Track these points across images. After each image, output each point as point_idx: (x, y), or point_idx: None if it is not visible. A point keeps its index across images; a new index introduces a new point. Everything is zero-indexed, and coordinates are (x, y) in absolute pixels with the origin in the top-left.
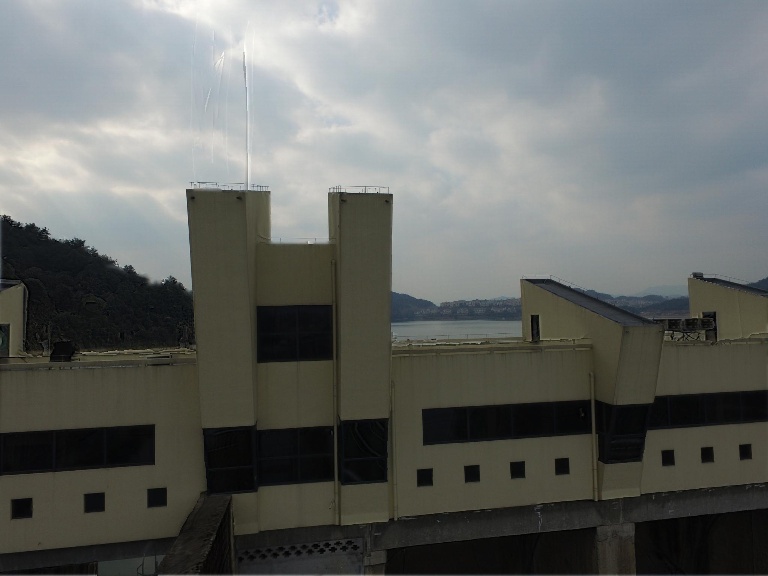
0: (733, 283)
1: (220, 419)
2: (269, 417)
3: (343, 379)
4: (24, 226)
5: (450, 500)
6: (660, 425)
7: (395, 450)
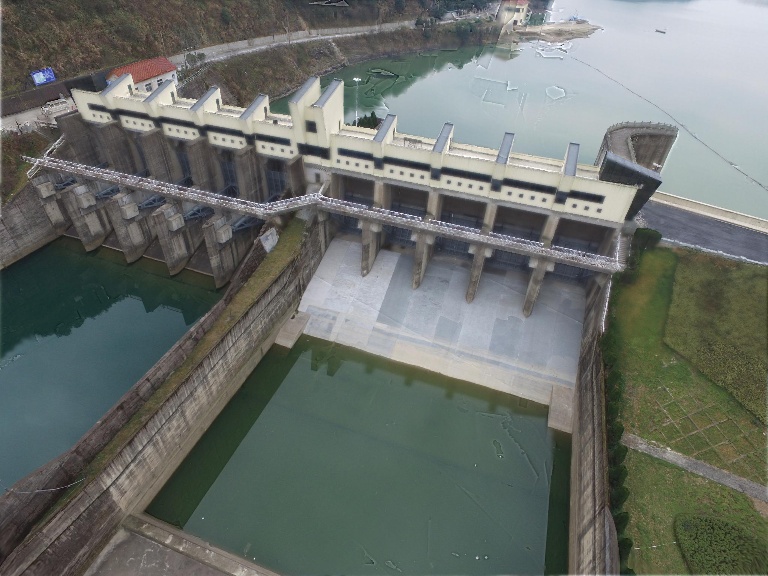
0: None
1: (299, 141)
2: (309, 142)
3: (318, 139)
4: None
5: (343, 167)
6: (391, 164)
7: (332, 154)
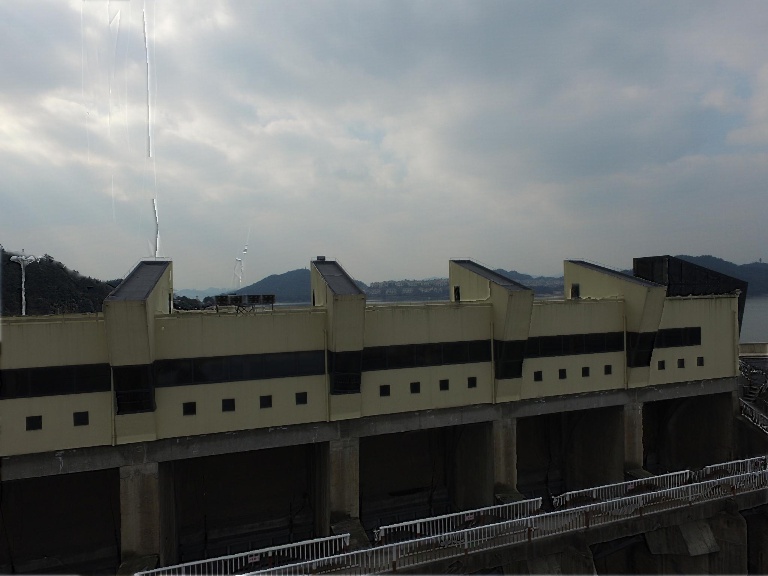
0: (336, 265)
1: None
2: None
3: None
4: None
5: None
6: (183, 382)
7: None
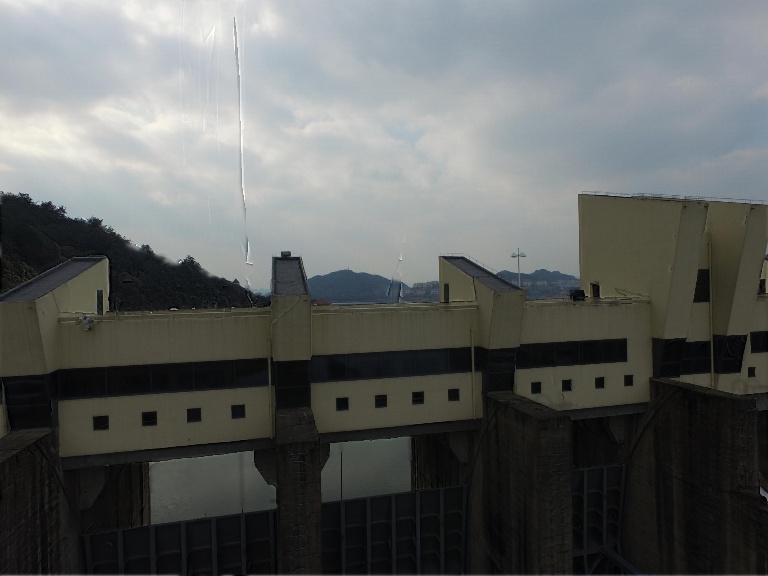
0: None
1: (671, 334)
2: None
3: (732, 311)
4: (40, 204)
5: (763, 386)
6: None
7: None
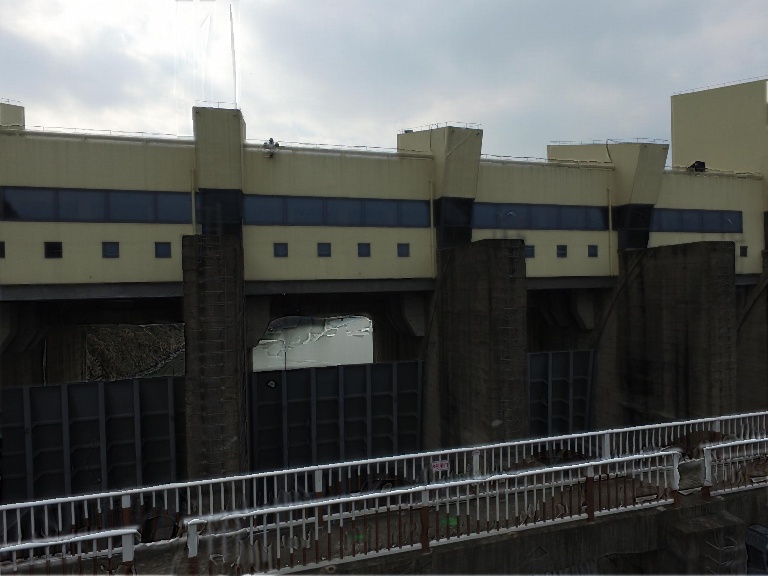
0: None
1: None
2: None
3: None
4: None
5: None
6: None
7: None
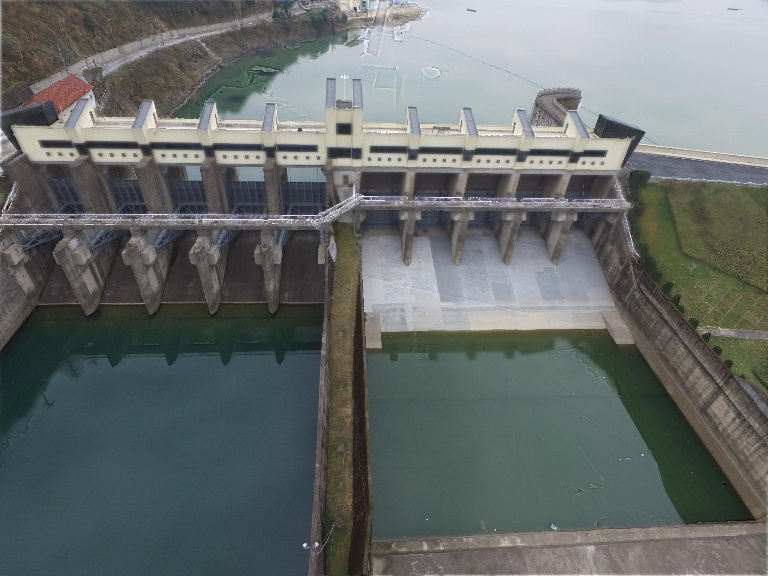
0: None
1: (330, 146)
2: (339, 145)
3: (353, 140)
4: None
5: (375, 164)
6: (424, 153)
7: (364, 153)
